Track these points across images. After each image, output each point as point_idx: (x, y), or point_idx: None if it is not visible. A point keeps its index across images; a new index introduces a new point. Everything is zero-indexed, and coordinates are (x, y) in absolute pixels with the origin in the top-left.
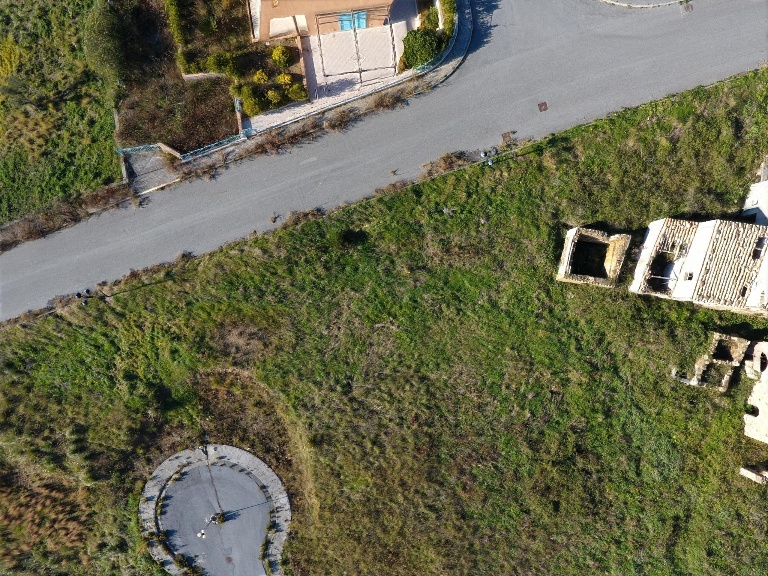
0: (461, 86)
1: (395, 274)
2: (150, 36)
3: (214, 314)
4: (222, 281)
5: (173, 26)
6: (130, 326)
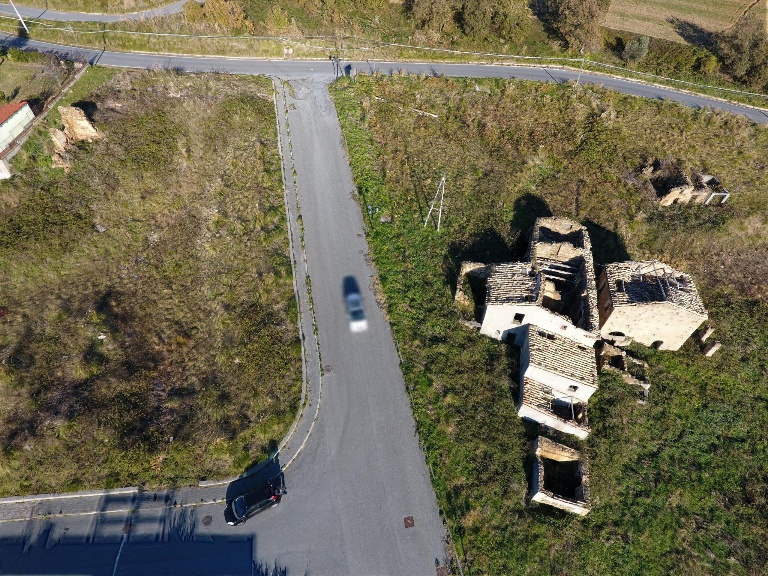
0: None
1: None
2: None
3: None
4: None
5: None
6: None
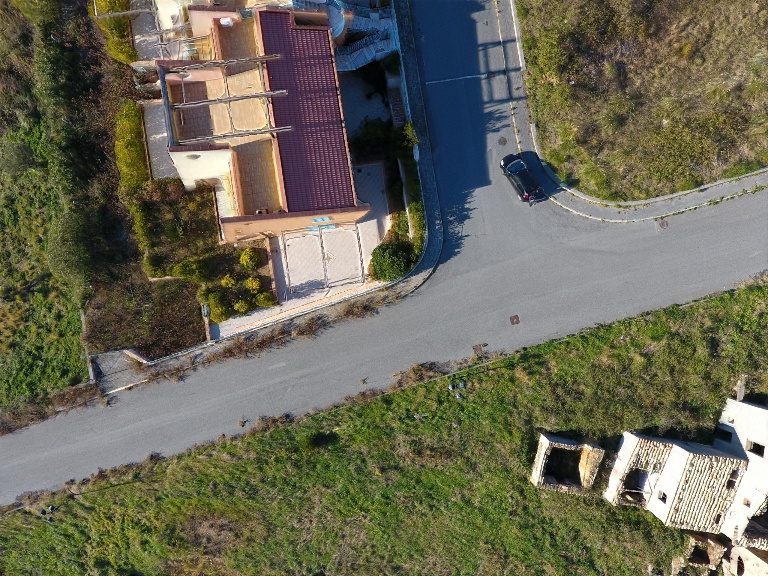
0: (431, 296)
1: (367, 472)
2: (117, 233)
3: (184, 508)
4: (191, 480)
5: (138, 233)
6: (100, 518)
